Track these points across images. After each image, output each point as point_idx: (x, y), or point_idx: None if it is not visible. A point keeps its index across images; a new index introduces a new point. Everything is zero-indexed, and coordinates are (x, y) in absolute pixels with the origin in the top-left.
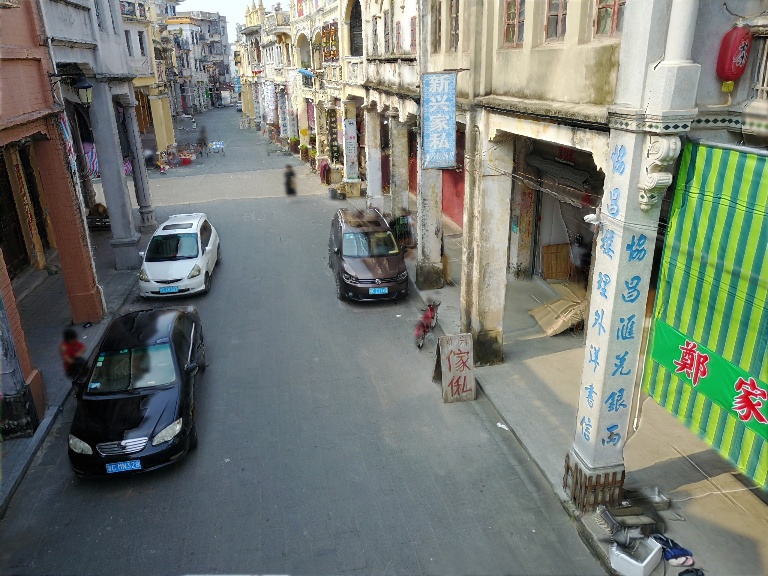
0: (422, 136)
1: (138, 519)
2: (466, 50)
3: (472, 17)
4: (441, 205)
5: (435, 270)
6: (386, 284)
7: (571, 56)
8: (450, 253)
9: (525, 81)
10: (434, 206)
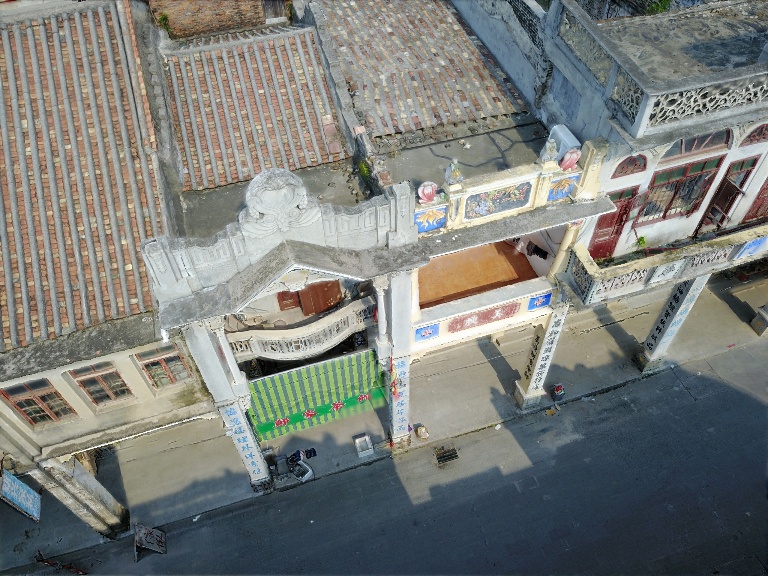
0: (25, 513)
1: None
2: None
3: None
4: None
5: None
6: None
7: (151, 402)
8: None
9: (97, 426)
10: None
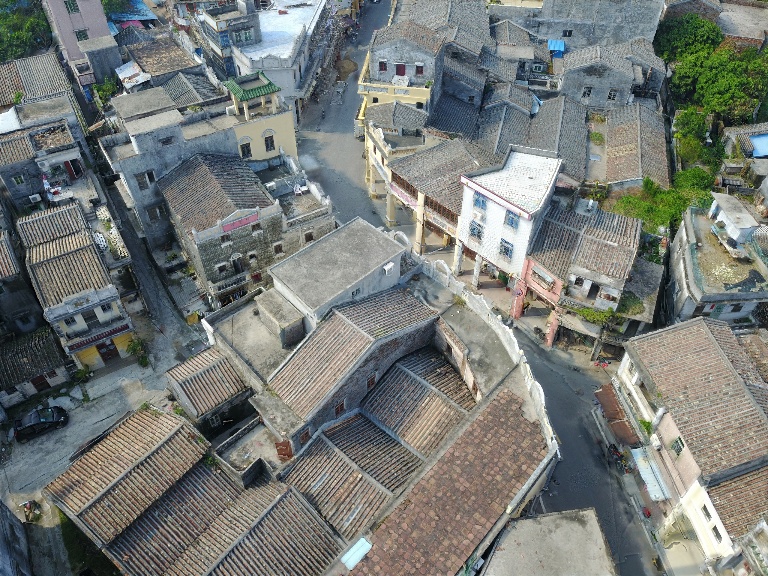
0: None
1: (375, 5)
2: None
3: None
4: None
5: None
6: None
7: None
8: None
9: None
10: None
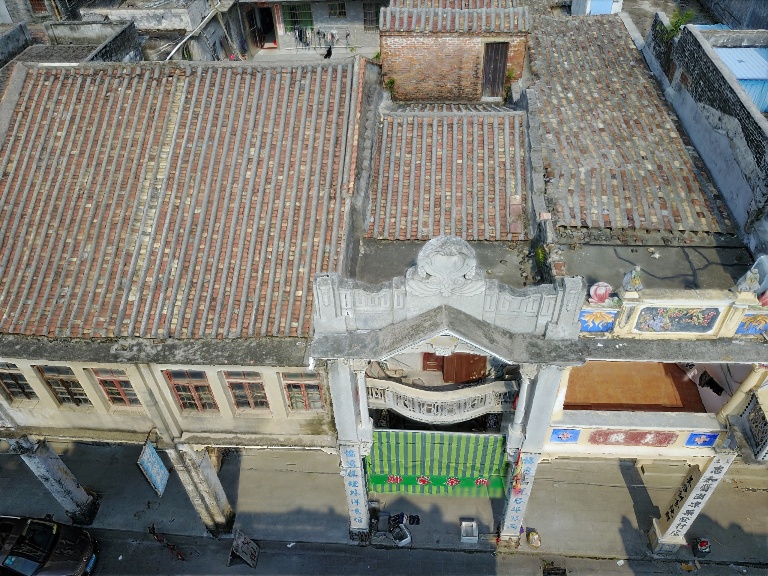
0: (153, 485)
1: None
2: (109, 409)
3: (151, 411)
4: (69, 470)
5: (90, 504)
6: (90, 553)
7: (283, 421)
8: (29, 470)
9: None
10: (66, 476)
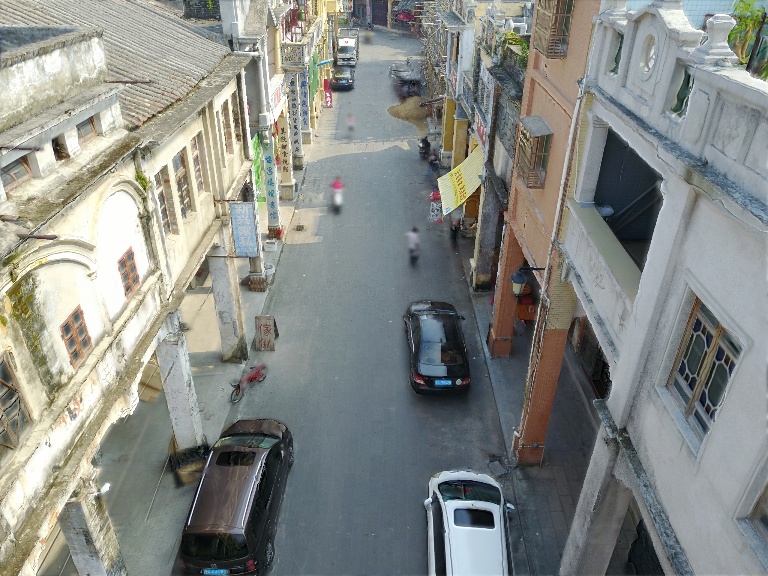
0: None
1: None
2: None
3: None
4: None
5: None
6: None
7: None
8: None
9: None
10: None
